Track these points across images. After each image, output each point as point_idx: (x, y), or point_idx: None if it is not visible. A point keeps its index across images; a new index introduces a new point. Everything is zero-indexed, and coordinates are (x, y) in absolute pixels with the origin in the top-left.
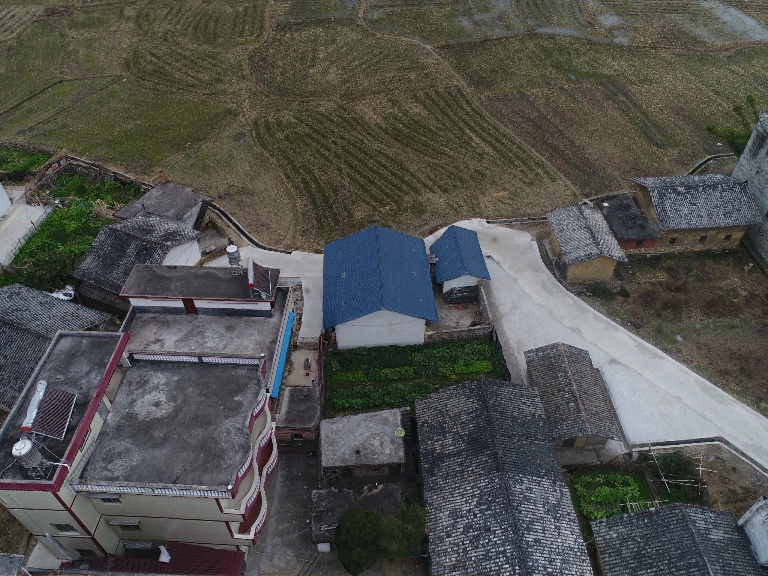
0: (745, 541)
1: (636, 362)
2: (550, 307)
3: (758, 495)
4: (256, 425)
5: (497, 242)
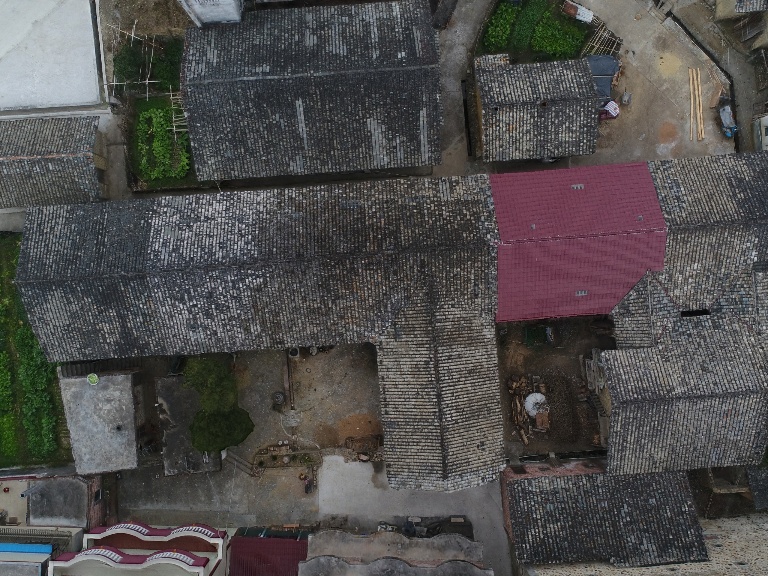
0: (217, 26)
1: None
2: None
3: None
4: (93, 568)
5: None
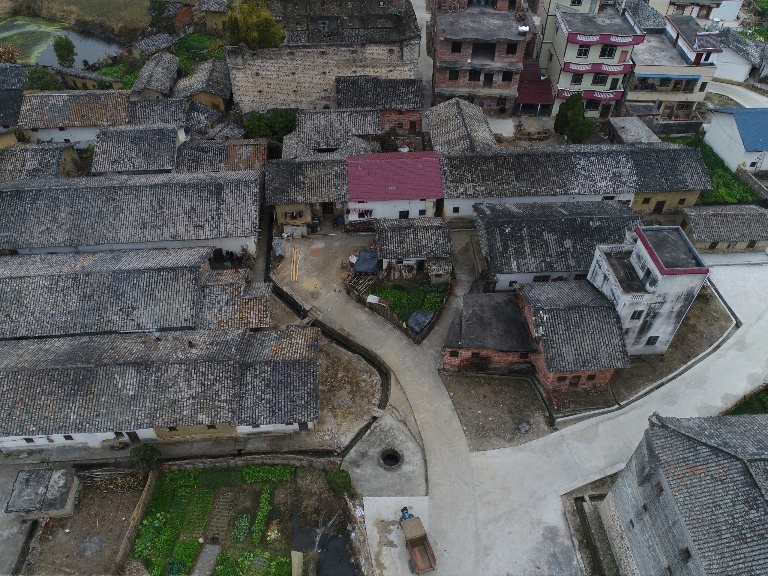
0: None
1: None
2: None
3: (693, 333)
4: None
5: None
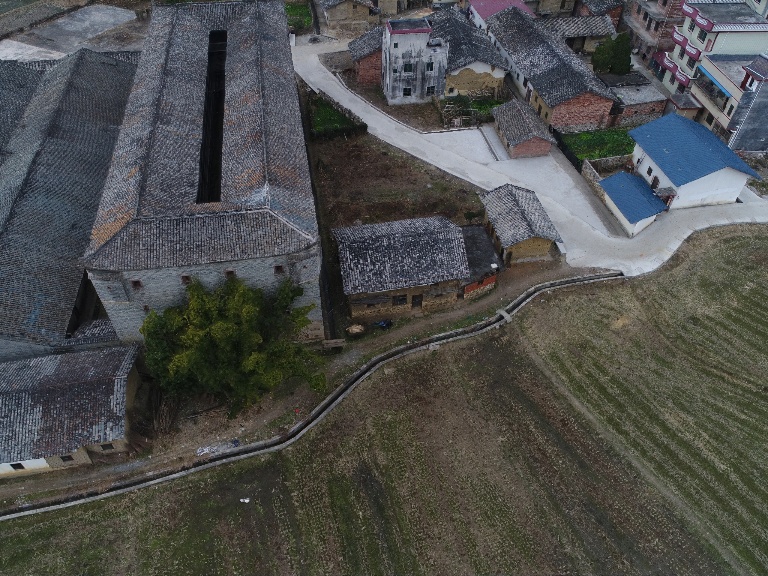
0: None
1: (469, 165)
2: (537, 194)
3: None
4: None
5: (602, 248)
